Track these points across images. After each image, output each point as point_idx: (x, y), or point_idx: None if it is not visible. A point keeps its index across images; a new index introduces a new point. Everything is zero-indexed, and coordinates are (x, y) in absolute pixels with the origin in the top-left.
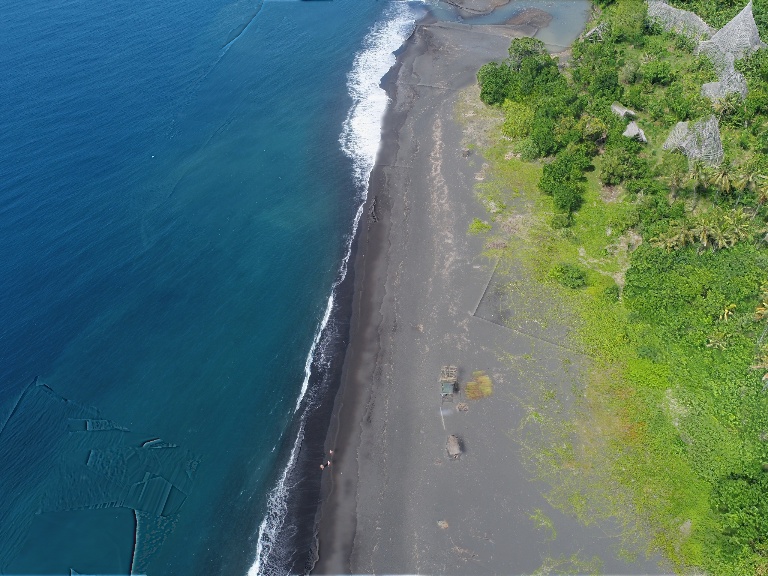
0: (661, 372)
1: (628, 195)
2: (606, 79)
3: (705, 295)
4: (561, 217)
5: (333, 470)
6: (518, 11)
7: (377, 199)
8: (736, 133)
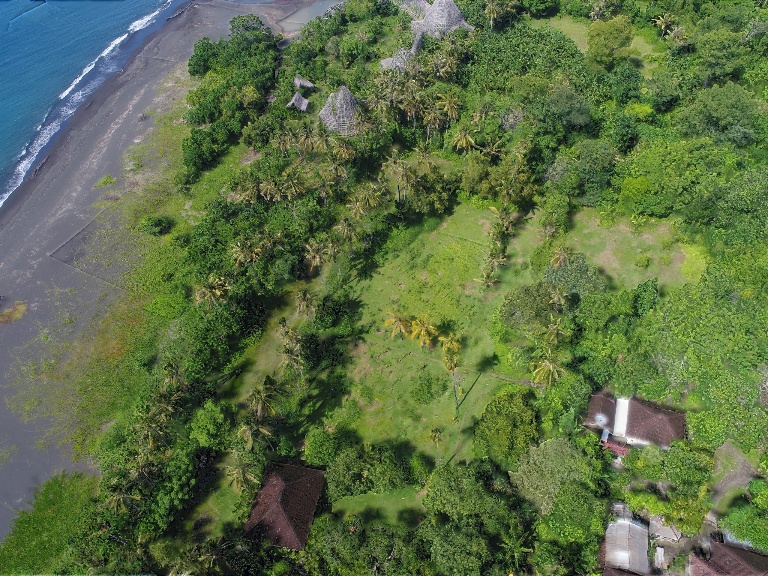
0: (175, 304)
1: None
2: (299, 54)
3: None
4: (181, 175)
5: None
6: None
7: (48, 158)
8: None
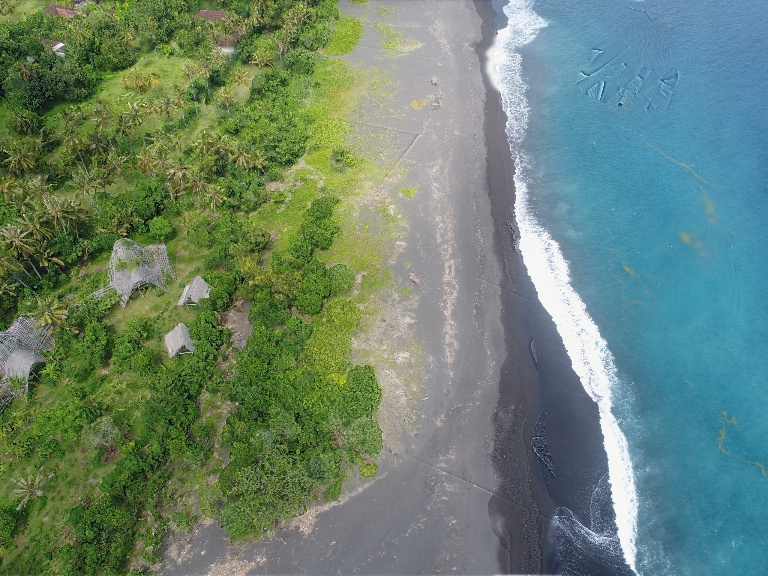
0: None
1: None
2: None
3: None
4: None
5: (497, 88)
6: None
7: (513, 247)
8: None
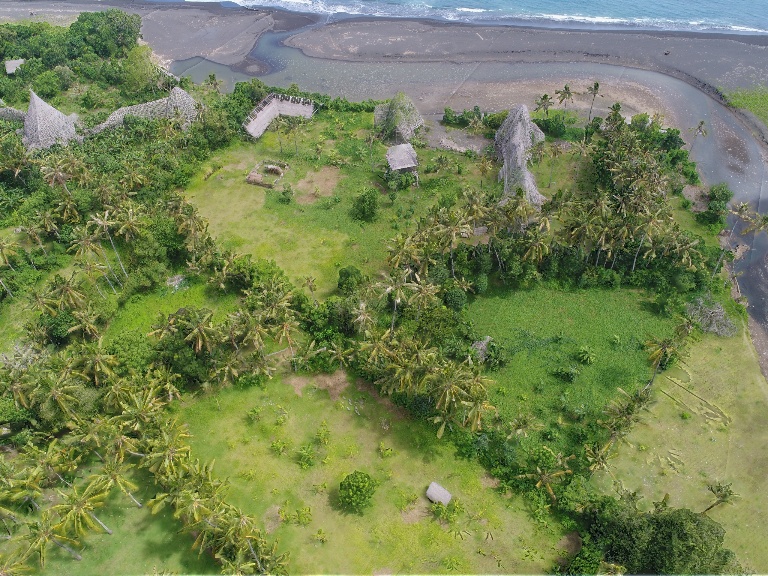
0: None
1: None
2: None
3: None
4: None
5: None
6: (282, 60)
7: None
8: None
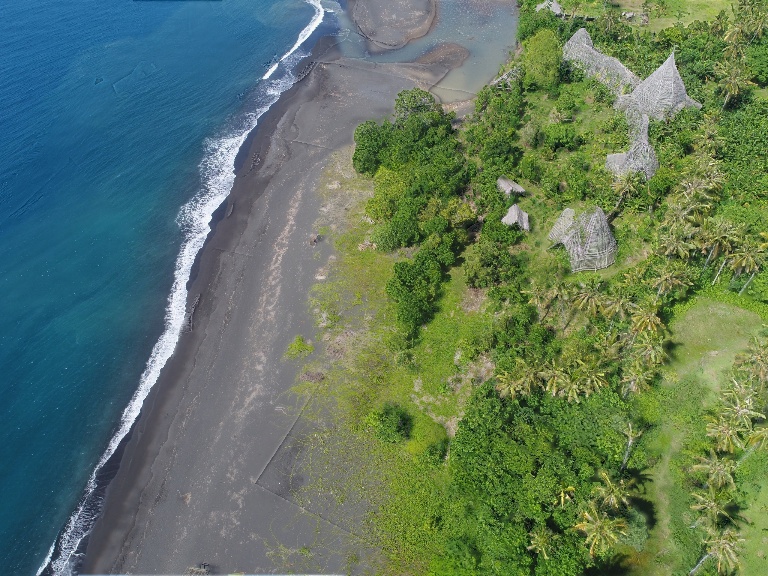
0: None
1: (493, 303)
2: (497, 145)
3: (535, 474)
4: (399, 338)
5: None
6: (433, 46)
7: (201, 298)
8: (640, 218)
